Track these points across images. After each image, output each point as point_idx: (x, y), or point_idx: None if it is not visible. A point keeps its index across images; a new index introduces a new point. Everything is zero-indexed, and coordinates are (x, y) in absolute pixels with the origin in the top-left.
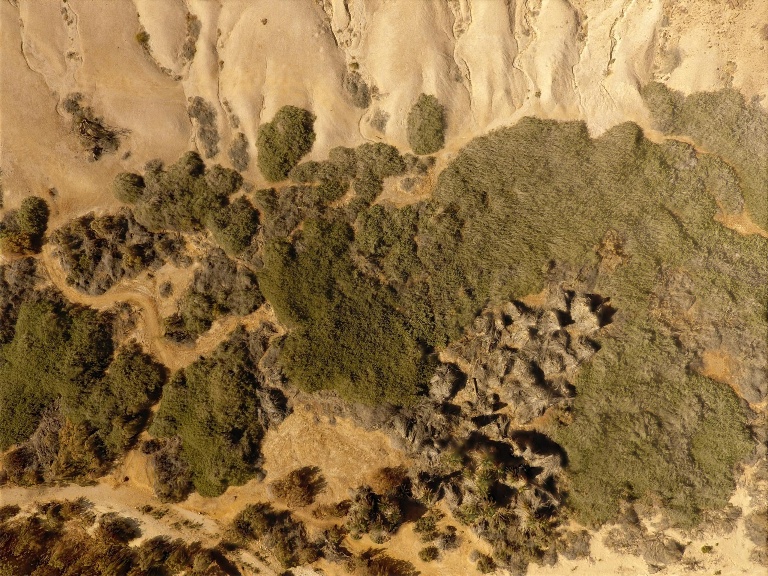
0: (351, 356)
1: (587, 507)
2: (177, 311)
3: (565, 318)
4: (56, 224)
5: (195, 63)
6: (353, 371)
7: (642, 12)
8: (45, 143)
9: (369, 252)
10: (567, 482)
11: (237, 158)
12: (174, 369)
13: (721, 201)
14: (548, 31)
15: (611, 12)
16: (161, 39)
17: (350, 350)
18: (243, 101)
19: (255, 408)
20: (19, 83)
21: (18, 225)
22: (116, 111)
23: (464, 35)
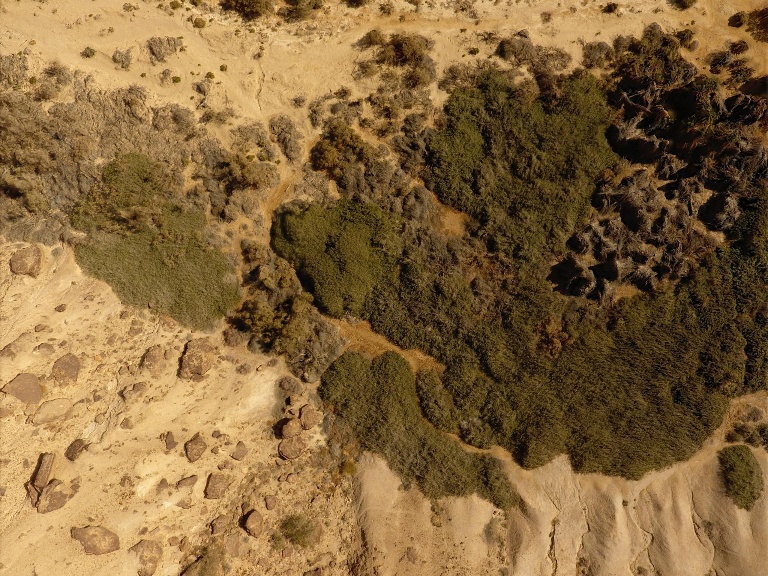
0: None
1: (593, 90)
2: None
3: (598, 272)
4: None
5: None
6: None
7: None
8: None
9: None
10: (609, 114)
11: None
12: None
13: (439, 384)
14: (622, 571)
15: None
16: None
17: None
18: None
19: None
20: None
21: None
22: None
23: (705, 572)
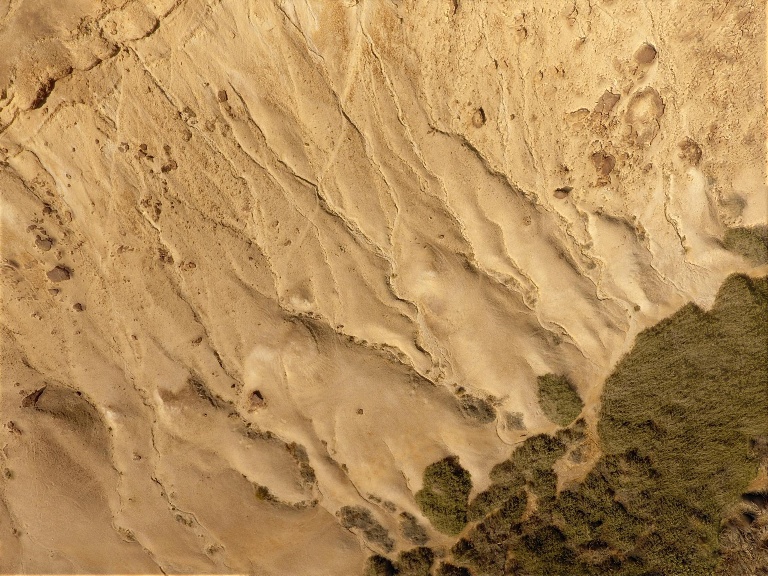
0: None
1: None
2: None
3: None
4: None
5: (321, 482)
6: None
7: (686, 186)
8: None
9: (587, 541)
10: None
11: (413, 536)
12: None
13: None
14: (612, 254)
15: (656, 202)
16: (279, 484)
17: None
18: (387, 488)
19: None
20: None
21: None
22: (283, 570)
23: (538, 302)
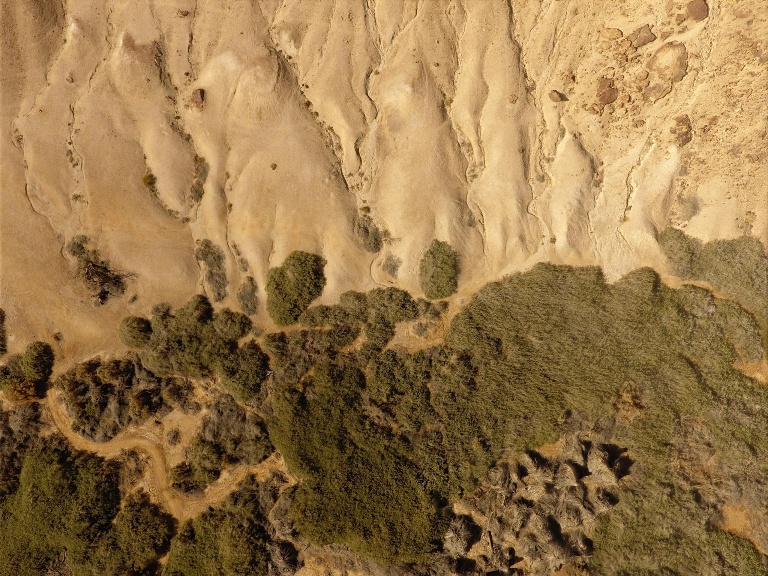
0: (363, 510)
1: None
2: (185, 460)
3: (582, 469)
4: (61, 368)
5: (203, 206)
6: (365, 526)
7: (659, 162)
8: (50, 287)
9: (381, 400)
10: None
11: (246, 302)
12: (182, 520)
13: (740, 349)
14: (563, 179)
15: (628, 160)
16: (168, 182)
17: (362, 504)
18: (252, 246)
19: (265, 563)
20: (23, 226)
21: (22, 371)
22: (122, 255)
23: (477, 180)
